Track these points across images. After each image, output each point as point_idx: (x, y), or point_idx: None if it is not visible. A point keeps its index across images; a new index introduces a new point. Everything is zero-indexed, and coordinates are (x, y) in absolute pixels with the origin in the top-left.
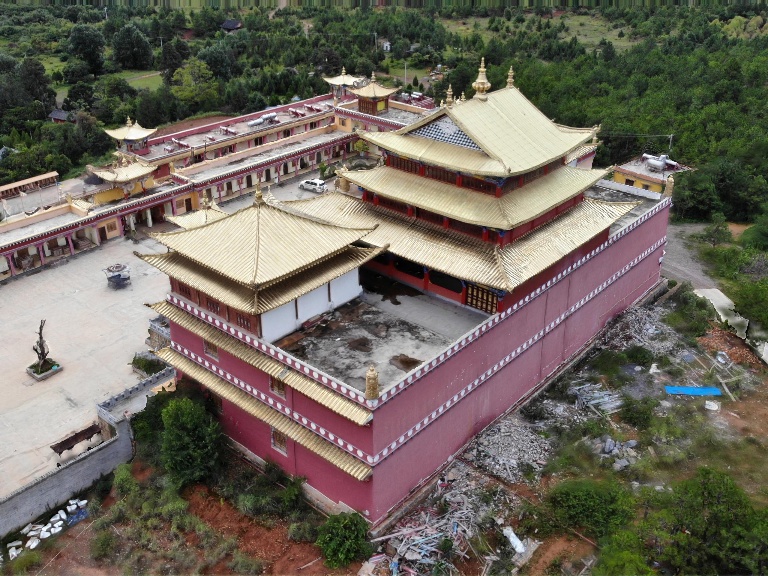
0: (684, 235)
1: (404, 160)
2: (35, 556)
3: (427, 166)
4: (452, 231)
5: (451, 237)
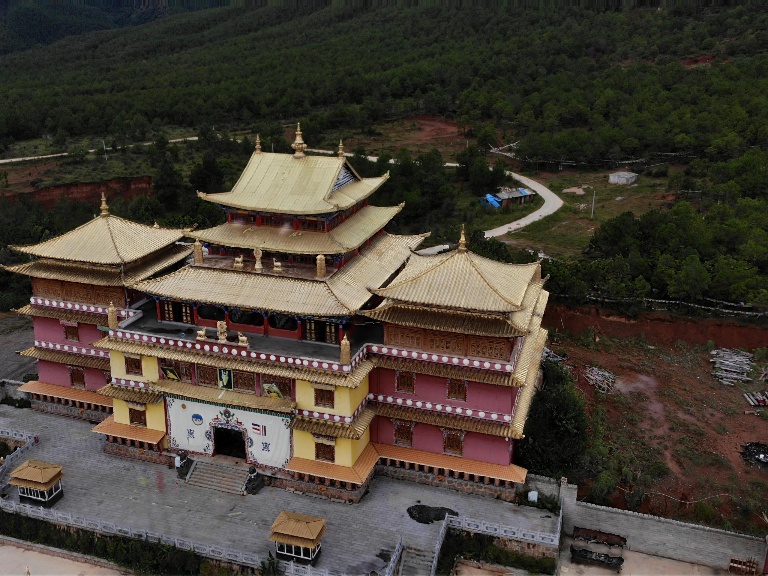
0: (3, 331)
1: (335, 217)
2: (700, 502)
3: (344, 211)
4: (371, 244)
5: (377, 246)
